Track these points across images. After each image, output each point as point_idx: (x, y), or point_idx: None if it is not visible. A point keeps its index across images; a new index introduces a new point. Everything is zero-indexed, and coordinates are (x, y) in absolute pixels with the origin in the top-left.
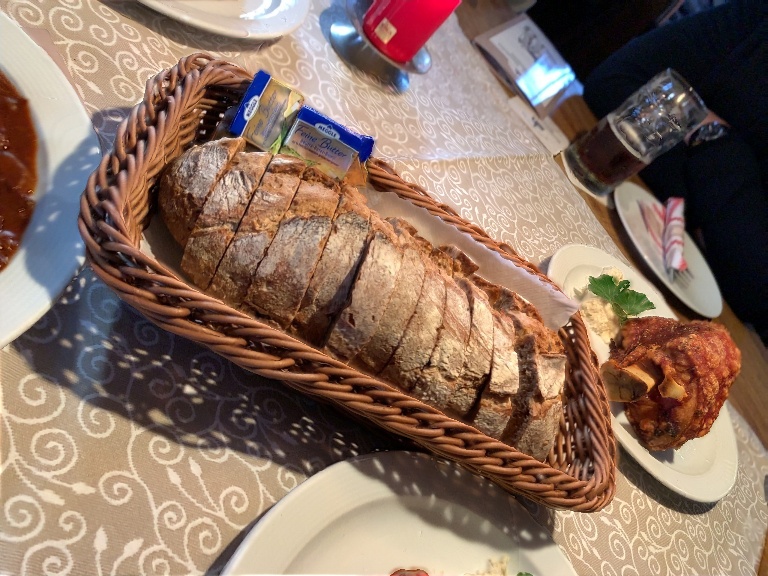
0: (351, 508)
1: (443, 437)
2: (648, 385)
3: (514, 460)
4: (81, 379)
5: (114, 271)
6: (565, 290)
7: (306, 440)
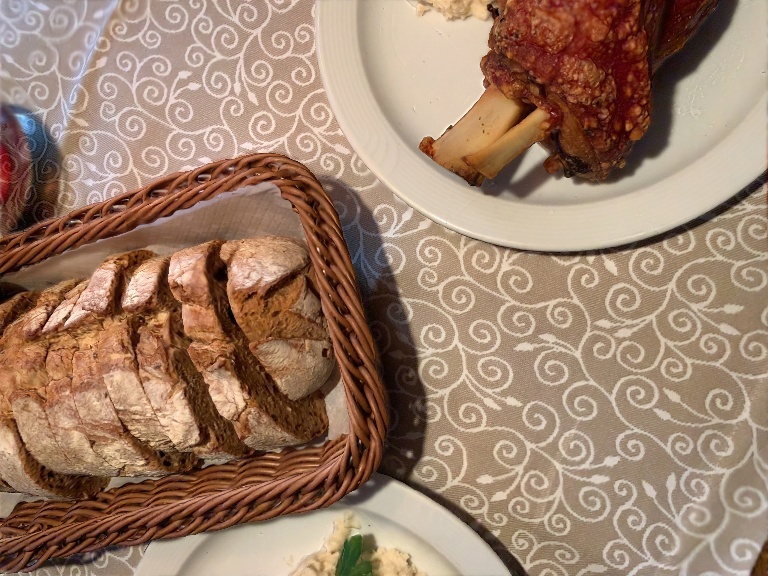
0: (179, 568)
1: (157, 534)
2: (487, 145)
3: (234, 504)
4: None
5: None
6: (375, 1)
7: None
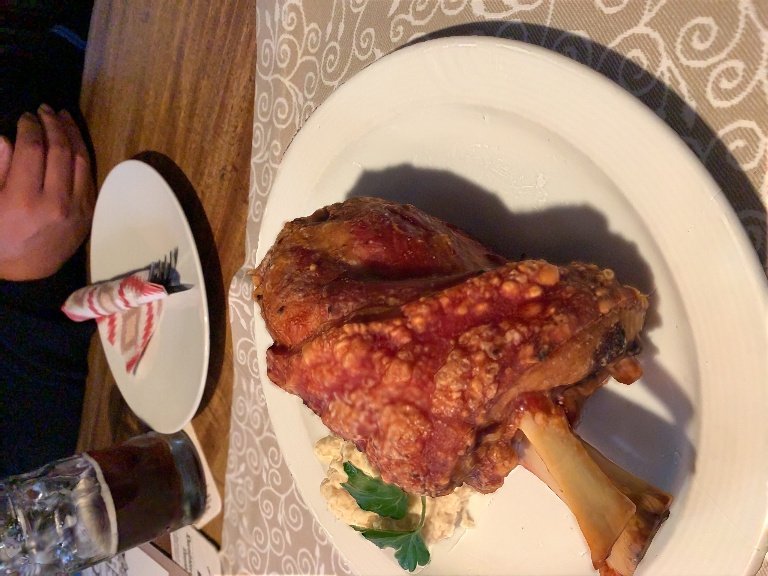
0: None
1: None
2: None
3: None
4: None
5: None
6: None
7: None
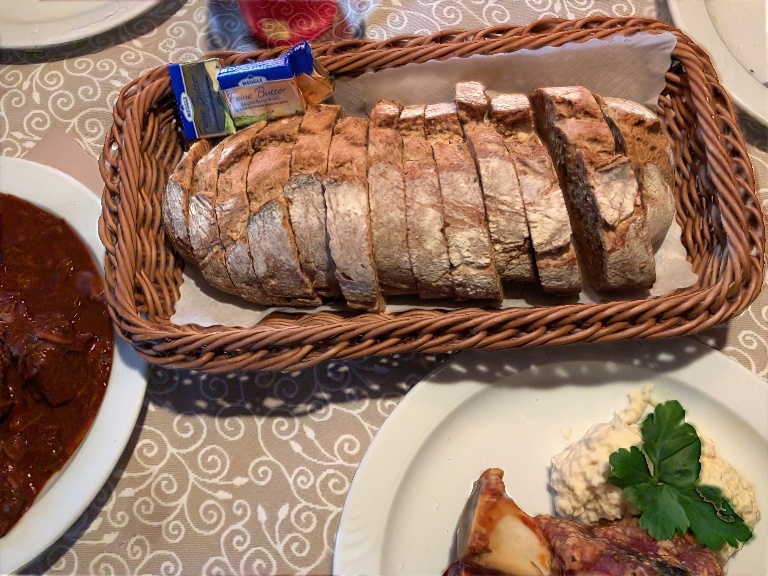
0: (443, 418)
1: (486, 339)
2: None
3: (587, 318)
4: (208, 403)
5: (150, 352)
6: None
7: (396, 363)
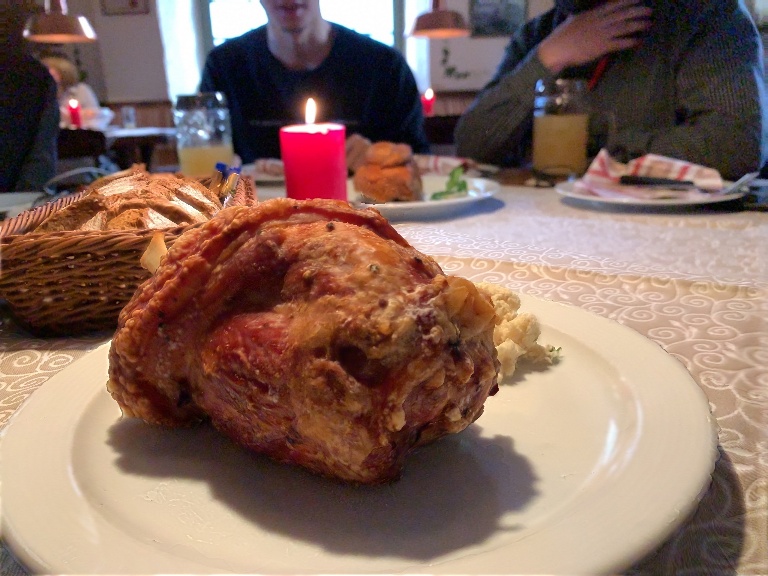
0: None
1: None
2: None
3: None
4: None
5: None
6: None
7: None
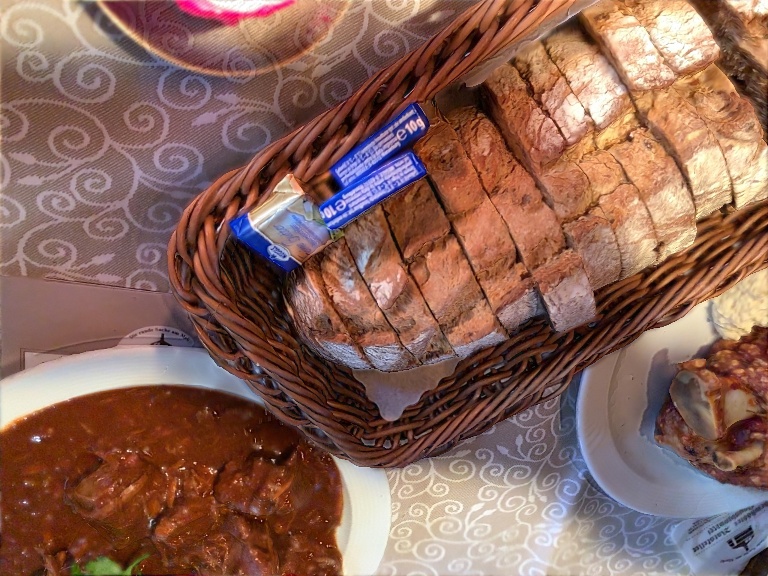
0: None
1: (697, 302)
2: None
3: None
4: None
5: None
6: None
7: None
